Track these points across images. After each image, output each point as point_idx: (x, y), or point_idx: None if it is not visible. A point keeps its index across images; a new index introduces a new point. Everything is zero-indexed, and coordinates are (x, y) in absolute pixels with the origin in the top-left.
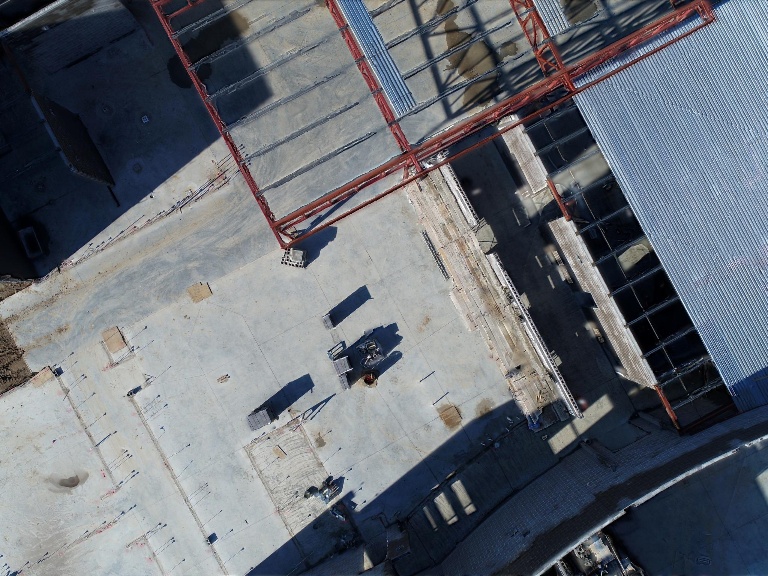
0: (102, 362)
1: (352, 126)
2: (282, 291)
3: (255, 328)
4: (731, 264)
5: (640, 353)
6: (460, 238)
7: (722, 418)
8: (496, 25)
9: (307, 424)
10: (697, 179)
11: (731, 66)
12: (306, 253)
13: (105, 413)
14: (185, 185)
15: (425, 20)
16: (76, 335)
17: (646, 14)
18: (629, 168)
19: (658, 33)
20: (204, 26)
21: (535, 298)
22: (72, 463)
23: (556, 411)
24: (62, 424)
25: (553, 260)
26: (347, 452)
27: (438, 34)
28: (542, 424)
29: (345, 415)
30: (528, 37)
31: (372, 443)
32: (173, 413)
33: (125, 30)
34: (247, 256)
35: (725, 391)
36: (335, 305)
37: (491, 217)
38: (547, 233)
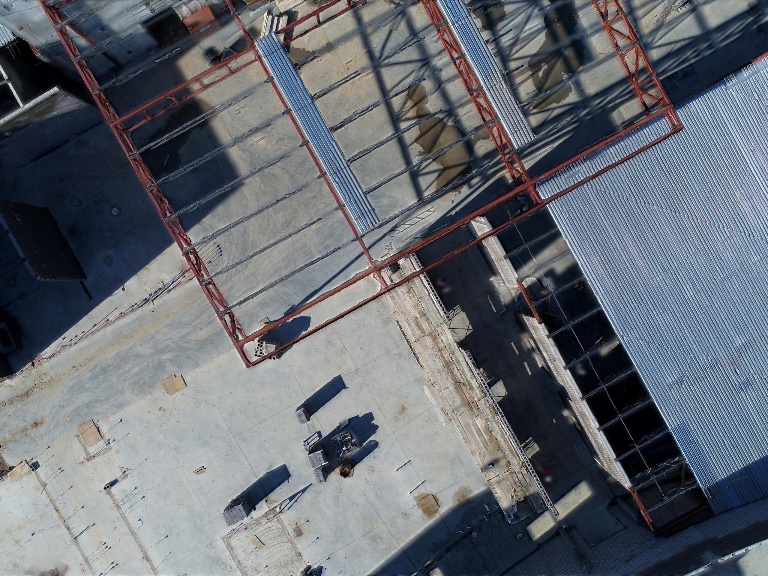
0: (78, 455)
1: (324, 214)
2: (256, 382)
3: (230, 419)
4: (706, 365)
5: (613, 456)
6: (433, 331)
7: (697, 520)
8: (469, 109)
9: (284, 514)
10: (671, 279)
11: (705, 163)
12: (280, 344)
13: (83, 506)
14: (157, 277)
15: (396, 105)
16: (52, 429)
17: (622, 94)
18: (601, 269)
19: (630, 131)
20: (165, 138)
21: (511, 385)
22: (51, 556)
23: (532, 503)
24: (40, 517)
25: (529, 346)
26: (325, 541)
27: (410, 119)
28: (518, 516)
29: (322, 505)
30: (495, 141)
31: (349, 532)
32: (150, 505)
33: (92, 123)
34: (221, 347)
35: (700, 492)
36: (310, 395)
37: (466, 304)
38: (522, 322)
